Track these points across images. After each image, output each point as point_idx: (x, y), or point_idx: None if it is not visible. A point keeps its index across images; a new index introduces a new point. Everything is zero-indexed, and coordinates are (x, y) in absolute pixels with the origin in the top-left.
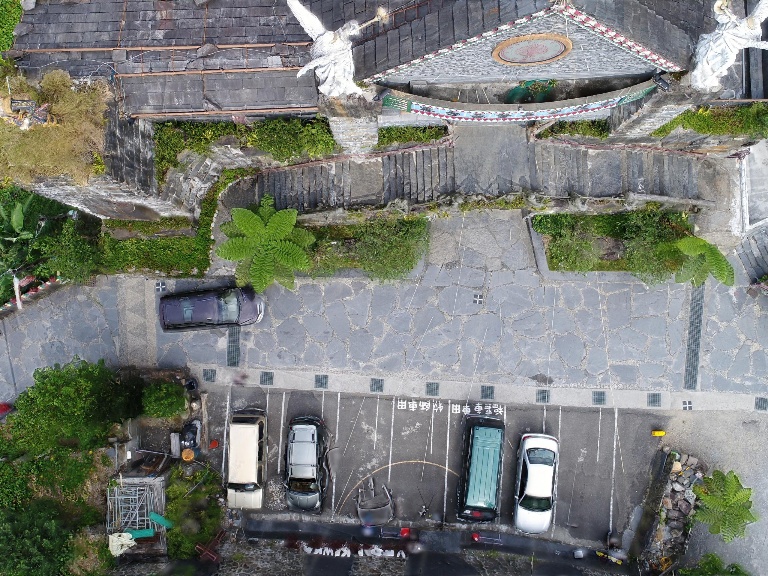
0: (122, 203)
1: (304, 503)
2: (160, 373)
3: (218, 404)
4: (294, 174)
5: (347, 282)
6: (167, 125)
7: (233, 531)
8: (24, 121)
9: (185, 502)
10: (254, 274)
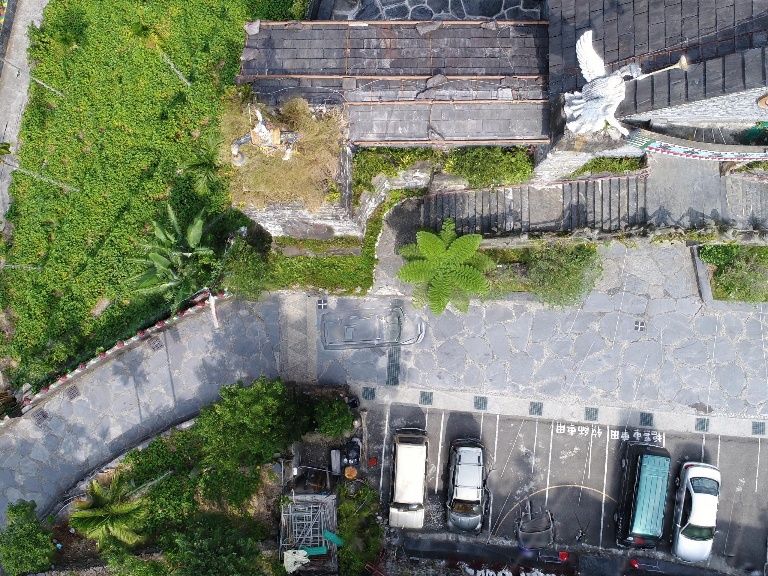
0: (317, 225)
1: (466, 524)
2: (323, 390)
3: (377, 422)
4: (465, 197)
5: (508, 305)
6: (371, 150)
7: (393, 549)
8: (286, 152)
9: (355, 521)
10: (433, 297)
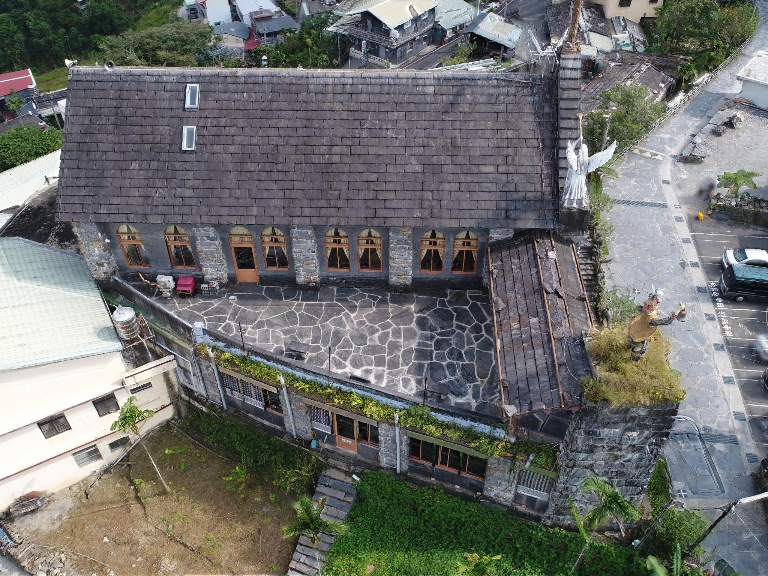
0: None
1: None
2: (767, 486)
3: None
4: None
5: None
6: None
7: None
8: None
9: None
10: None
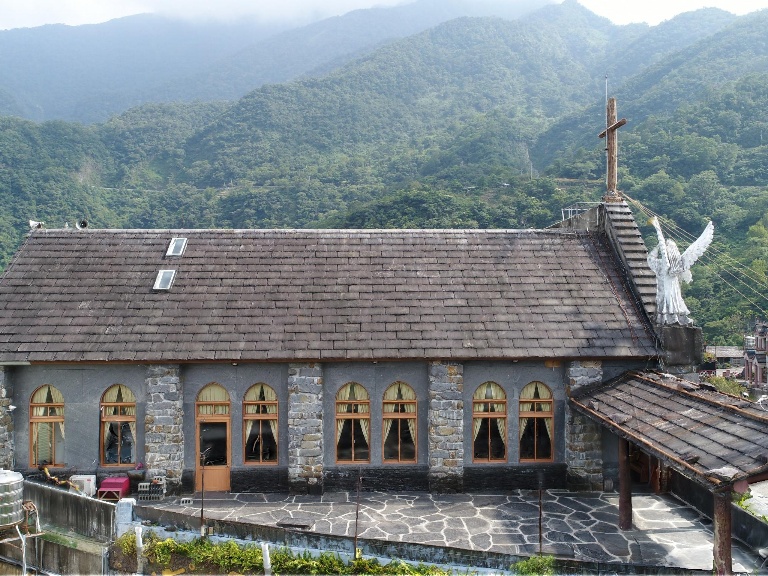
0: None
1: None
2: None
3: None
4: None
5: None
6: None
7: None
8: None
9: None
10: None
